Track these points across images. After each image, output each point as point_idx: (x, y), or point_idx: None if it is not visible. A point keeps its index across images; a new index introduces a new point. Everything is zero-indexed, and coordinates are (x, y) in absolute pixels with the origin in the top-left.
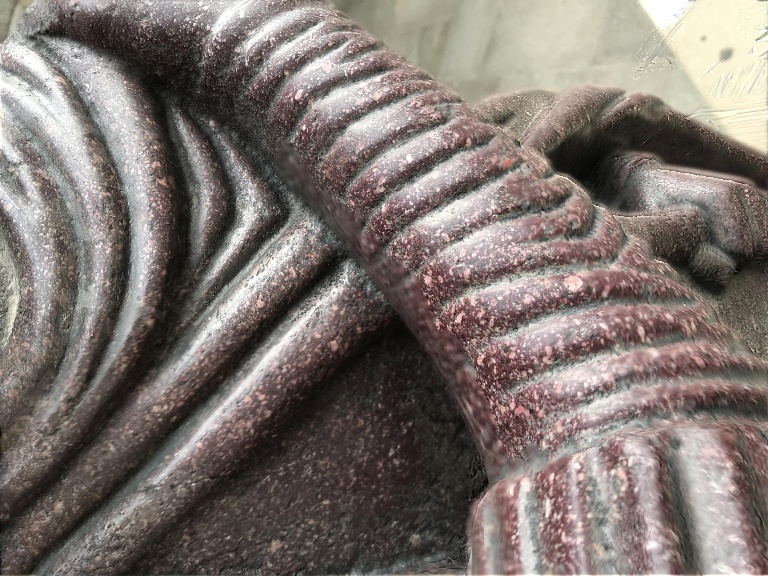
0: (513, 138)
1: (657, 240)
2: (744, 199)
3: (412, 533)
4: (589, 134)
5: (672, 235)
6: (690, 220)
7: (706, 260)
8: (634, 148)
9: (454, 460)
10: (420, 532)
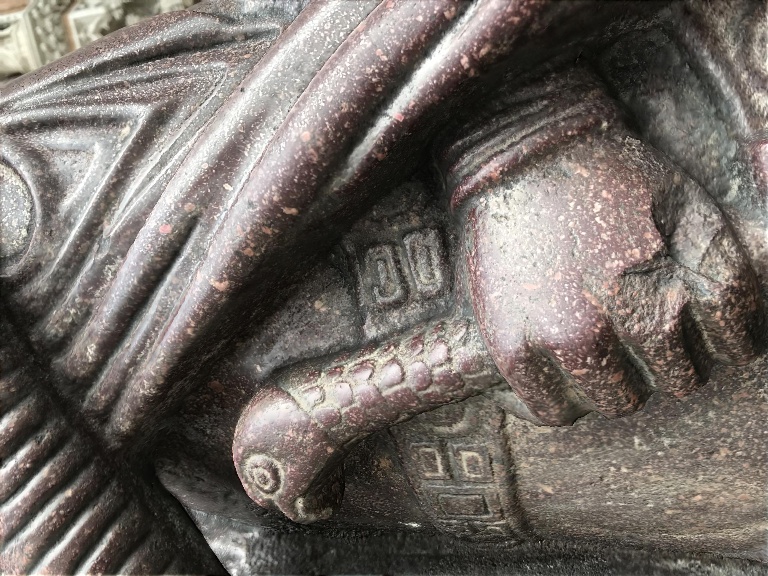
0: (4, 535)
1: (342, 435)
2: (555, 360)
3: (230, 518)
4: (319, 208)
5: (385, 414)
6: (447, 375)
7: (499, 402)
8: (601, 6)
9: (233, 504)
10: (235, 518)
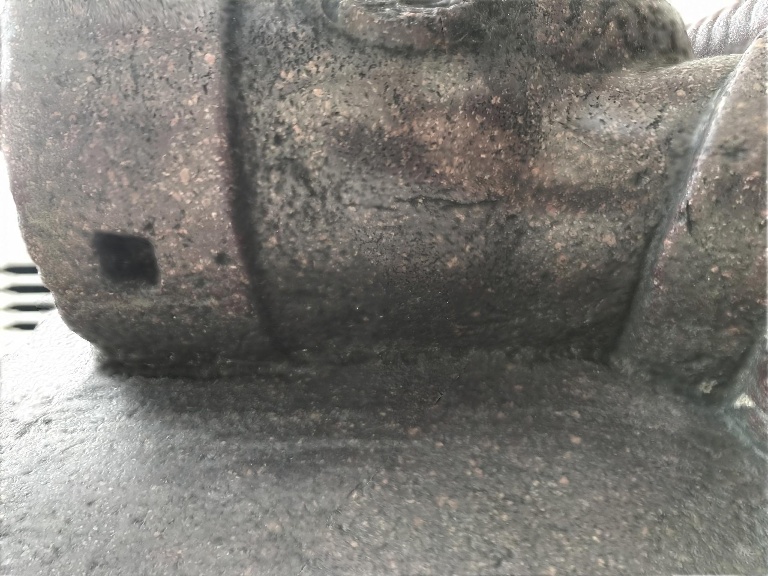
0: None
1: None
2: None
3: None
4: None
5: None
6: None
7: None
8: None
9: None
10: None
